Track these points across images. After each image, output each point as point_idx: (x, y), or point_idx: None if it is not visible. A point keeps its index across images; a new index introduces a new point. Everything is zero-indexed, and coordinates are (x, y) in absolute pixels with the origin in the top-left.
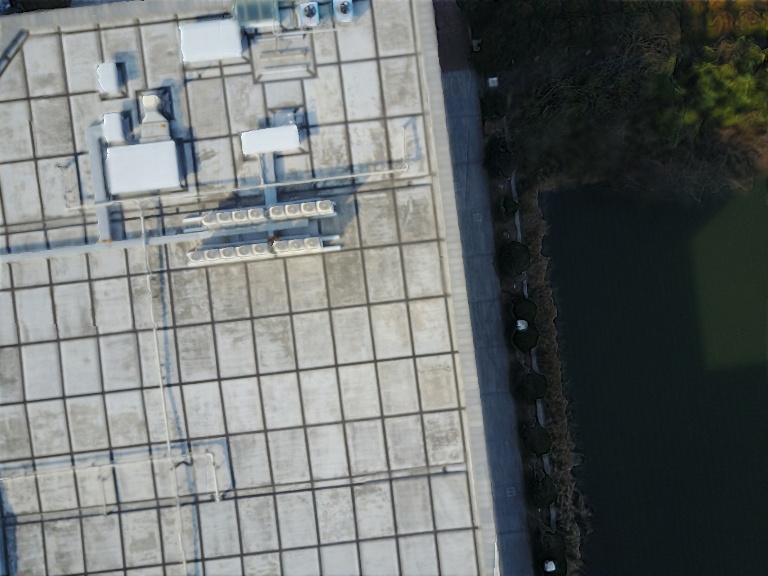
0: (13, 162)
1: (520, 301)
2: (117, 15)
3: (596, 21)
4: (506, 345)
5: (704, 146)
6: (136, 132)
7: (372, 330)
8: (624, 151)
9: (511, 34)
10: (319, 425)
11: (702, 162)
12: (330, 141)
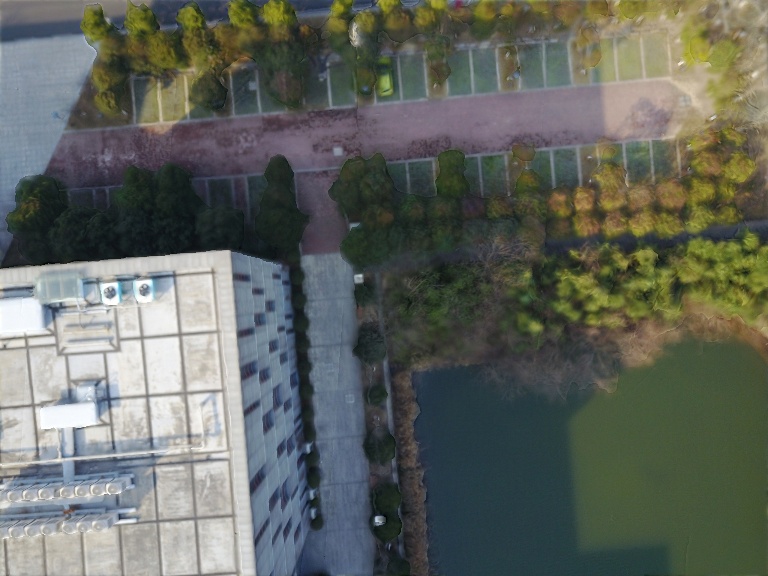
0: None
1: (385, 489)
2: None
3: (457, 229)
4: (371, 531)
5: (570, 346)
6: None
7: None
8: (490, 348)
9: (372, 239)
10: None
11: (566, 363)
12: (131, 414)
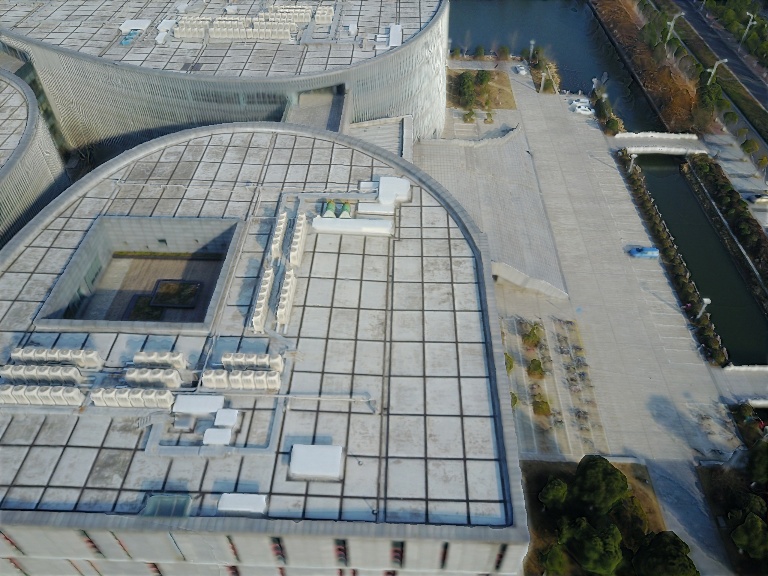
0: (5, 13)
1: None
2: None
3: None
4: None
5: None
6: None
7: None
8: None
9: None
10: None
11: None
12: None
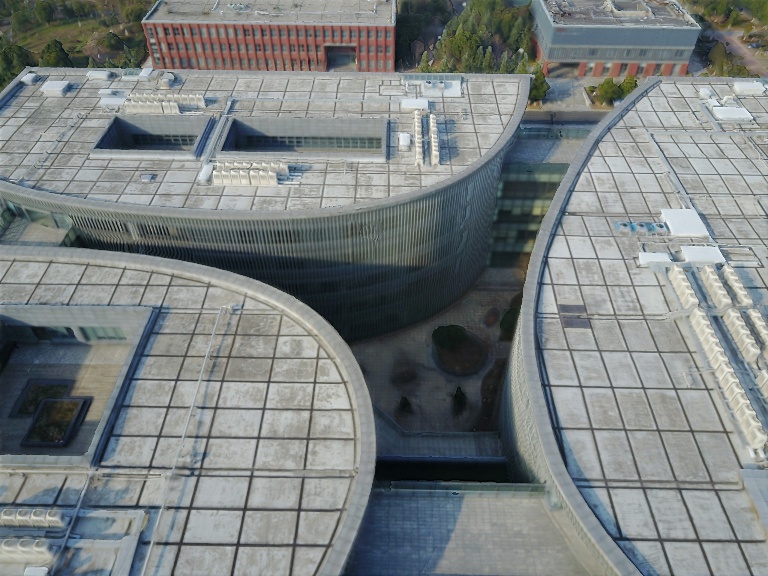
0: (663, 111)
1: None
2: (701, 80)
3: None
4: None
5: None
6: None
7: None
8: None
9: None
10: None
11: None
12: None
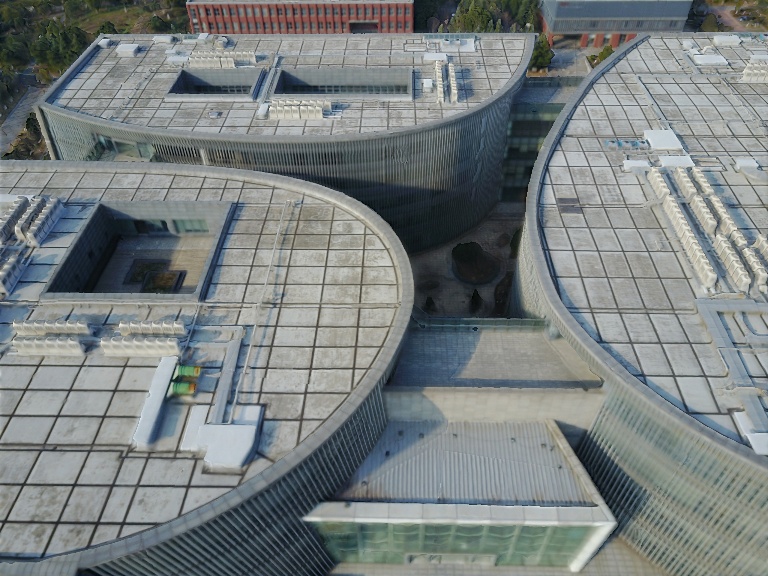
0: None
1: None
2: (685, 35)
3: None
4: None
5: None
6: None
7: None
8: None
9: None
10: None
11: None
12: None
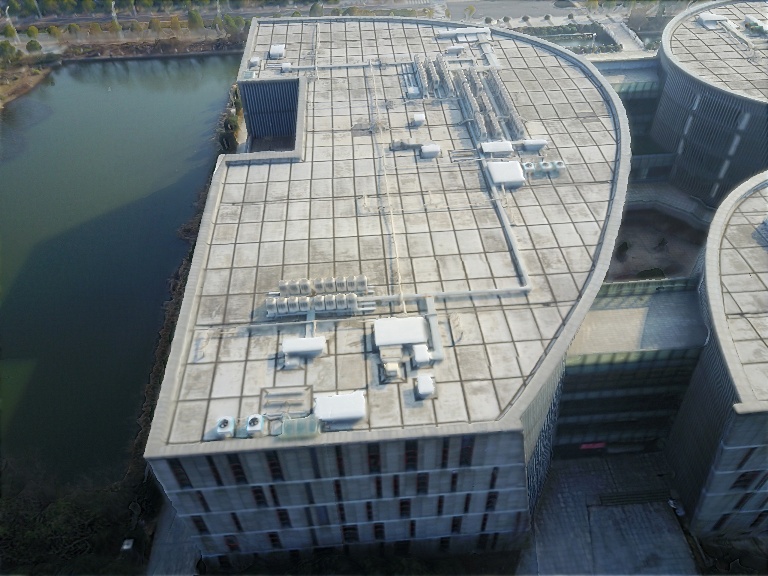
0: (501, 343)
1: None
2: None
3: None
4: None
5: None
6: (408, 358)
7: (258, 256)
8: None
9: (93, 573)
10: (301, 220)
11: None
12: (262, 350)
